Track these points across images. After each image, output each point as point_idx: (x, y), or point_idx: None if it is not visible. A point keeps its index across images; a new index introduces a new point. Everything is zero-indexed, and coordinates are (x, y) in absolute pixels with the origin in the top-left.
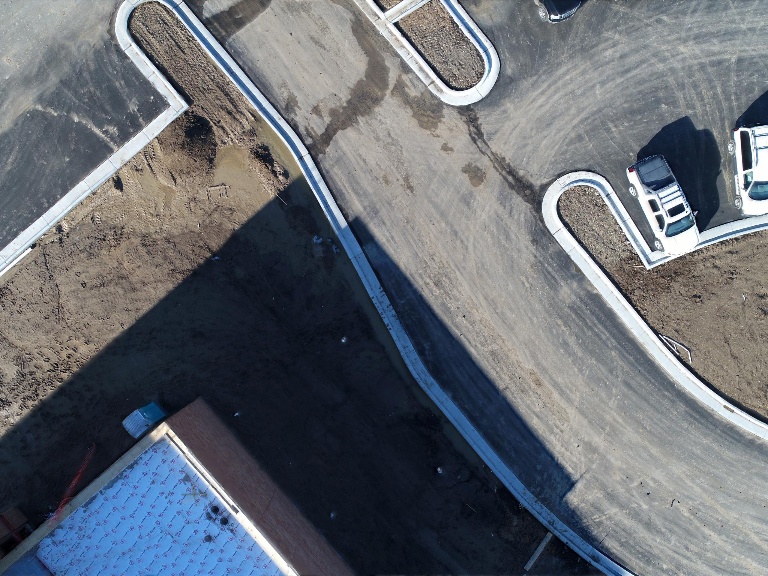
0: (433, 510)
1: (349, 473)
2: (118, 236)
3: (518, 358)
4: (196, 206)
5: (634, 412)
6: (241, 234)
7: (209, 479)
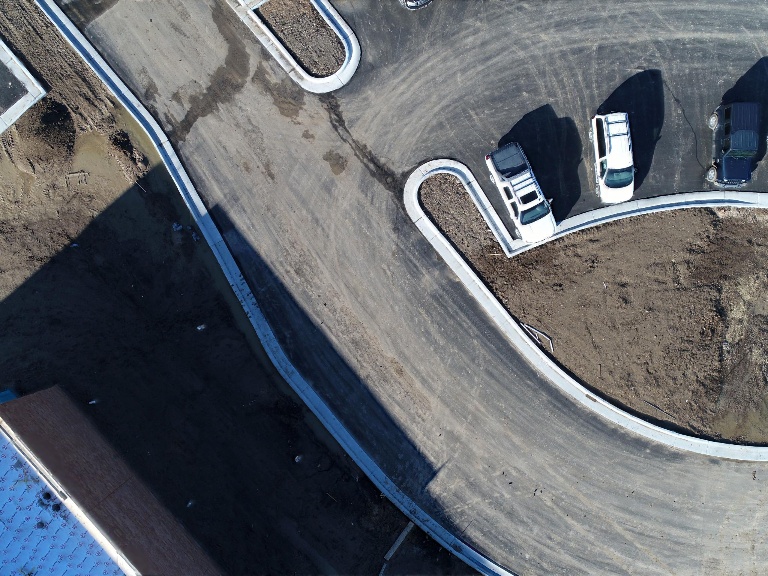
0: (293, 499)
1: (208, 462)
2: None
3: (380, 347)
4: (55, 193)
5: (496, 401)
6: (100, 221)
7: (37, 465)
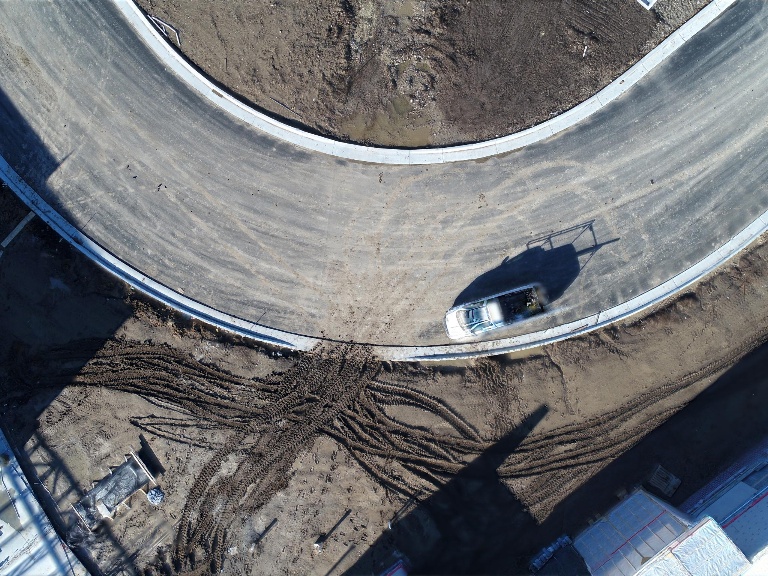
0: None
1: None
2: None
3: (6, 35)
4: None
5: (123, 94)
6: None
7: None
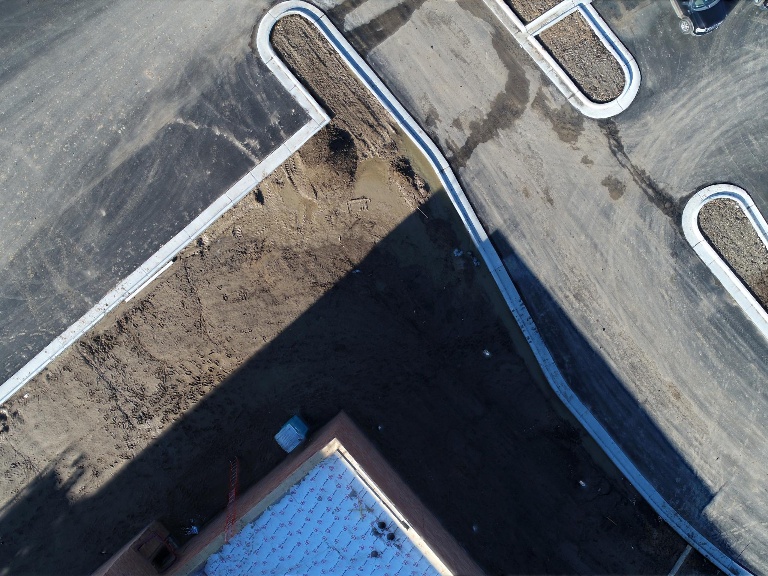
0: (573, 523)
1: (490, 486)
2: (259, 249)
3: (657, 371)
4: (337, 219)
5: None
6: (382, 247)
7: (380, 495)
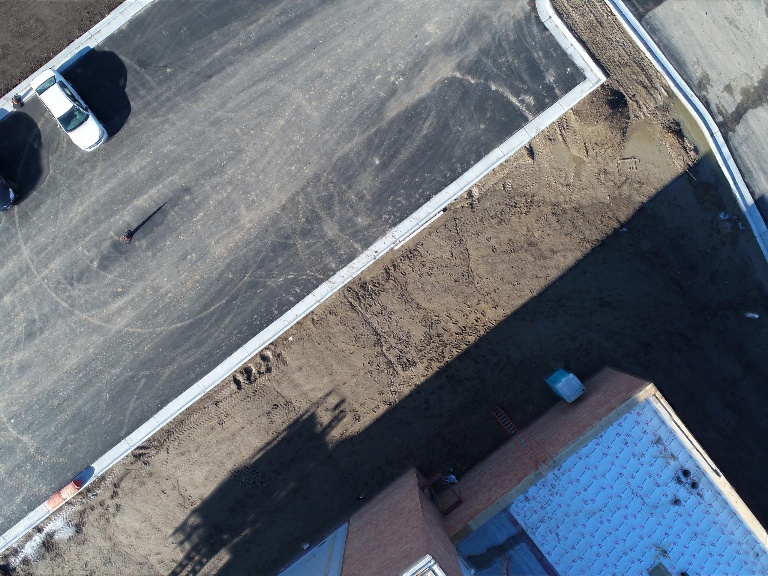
0: None
1: (748, 449)
2: (528, 204)
3: None
4: (606, 178)
5: None
6: (649, 207)
7: (693, 442)
